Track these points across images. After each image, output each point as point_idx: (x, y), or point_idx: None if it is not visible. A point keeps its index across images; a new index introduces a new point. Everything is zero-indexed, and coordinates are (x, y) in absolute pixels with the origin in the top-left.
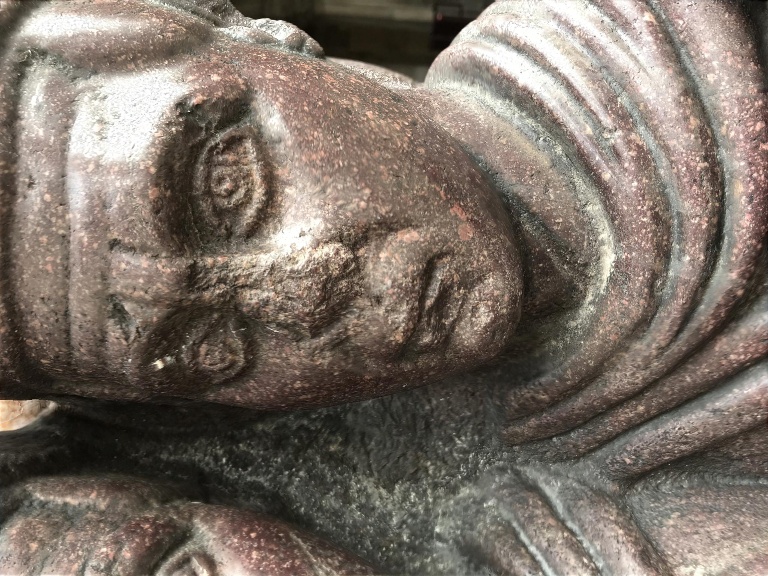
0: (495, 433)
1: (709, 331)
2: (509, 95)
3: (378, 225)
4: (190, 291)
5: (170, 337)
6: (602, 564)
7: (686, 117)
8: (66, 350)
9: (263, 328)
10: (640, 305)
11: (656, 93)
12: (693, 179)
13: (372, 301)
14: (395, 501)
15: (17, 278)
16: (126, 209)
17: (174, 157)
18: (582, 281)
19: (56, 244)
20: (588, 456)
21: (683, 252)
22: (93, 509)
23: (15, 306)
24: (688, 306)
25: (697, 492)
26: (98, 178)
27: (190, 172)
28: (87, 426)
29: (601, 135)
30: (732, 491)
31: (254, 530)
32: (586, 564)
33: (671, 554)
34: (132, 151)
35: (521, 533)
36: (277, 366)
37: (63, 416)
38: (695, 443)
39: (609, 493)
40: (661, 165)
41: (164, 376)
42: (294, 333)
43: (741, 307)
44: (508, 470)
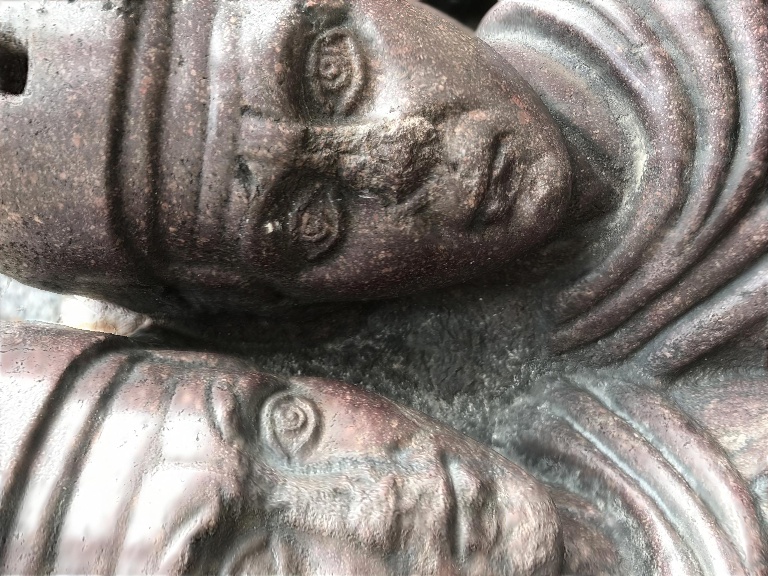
0: (545, 342)
1: (733, 212)
2: (548, 33)
3: (453, 105)
4: (303, 152)
5: (280, 202)
6: (652, 438)
7: (700, 27)
8: (193, 214)
9: (356, 198)
10: (672, 194)
11: (674, 11)
12: (710, 77)
13: (449, 168)
14: (454, 411)
15: (164, 142)
16: (256, 80)
17: (293, 42)
18: (619, 186)
19: (198, 111)
20: (631, 357)
21: (706, 142)
22: (205, 366)
23: (159, 168)
24: (713, 190)
25: (733, 383)
26: (235, 56)
27: (304, 57)
28: (179, 337)
29: (629, 51)
30: (765, 380)
31: (345, 385)
32: (637, 438)
33: (714, 429)
34: (261, 35)
35: (574, 424)
36: (365, 237)
37: (158, 328)
38: (728, 328)
39: (653, 387)
40: (682, 71)
41: (272, 242)
42: (383, 199)
43: (759, 192)
44: (558, 378)
